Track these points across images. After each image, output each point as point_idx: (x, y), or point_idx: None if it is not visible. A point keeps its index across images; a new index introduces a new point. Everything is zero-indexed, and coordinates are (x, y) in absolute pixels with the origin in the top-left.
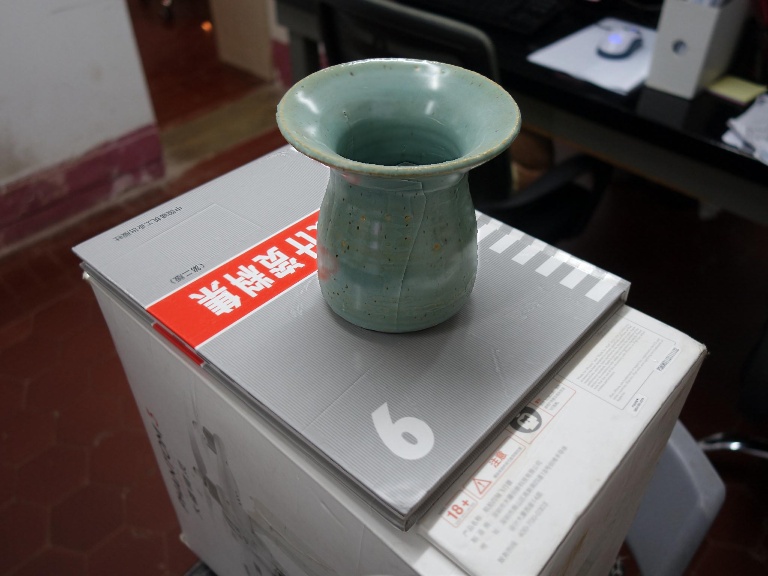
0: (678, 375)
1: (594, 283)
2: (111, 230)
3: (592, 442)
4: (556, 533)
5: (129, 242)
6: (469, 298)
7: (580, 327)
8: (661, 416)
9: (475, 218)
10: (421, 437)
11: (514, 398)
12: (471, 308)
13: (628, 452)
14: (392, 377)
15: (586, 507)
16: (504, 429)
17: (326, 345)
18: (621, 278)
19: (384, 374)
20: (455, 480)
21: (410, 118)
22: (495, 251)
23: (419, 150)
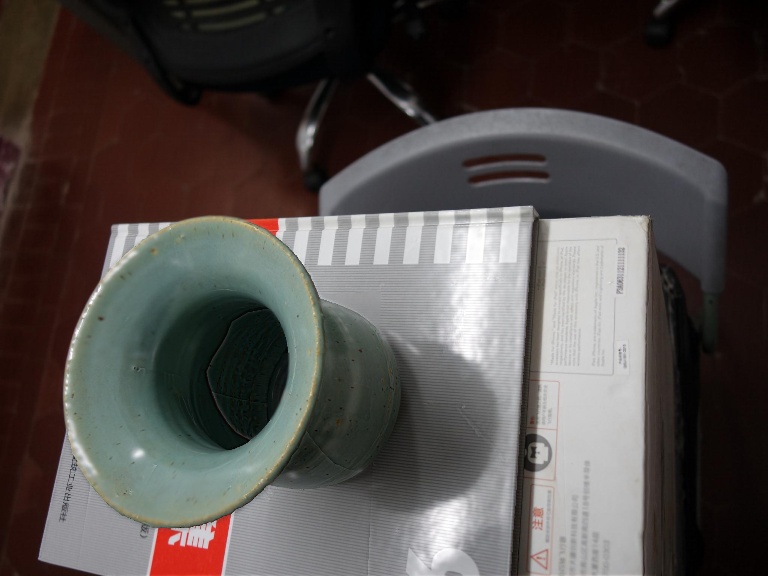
0: (641, 287)
1: (498, 236)
2: (50, 512)
3: (607, 438)
4: (634, 569)
5: (74, 515)
6: (398, 354)
7: (519, 314)
8: (650, 342)
9: (345, 332)
10: (463, 569)
11: (513, 460)
12: (407, 366)
13: (645, 426)
14: (395, 513)
15: (643, 520)
16: (523, 479)
17: (317, 516)
18: (519, 206)
19: (386, 515)
20: (517, 570)
21: (197, 302)
22: (381, 264)
23: (234, 308)
